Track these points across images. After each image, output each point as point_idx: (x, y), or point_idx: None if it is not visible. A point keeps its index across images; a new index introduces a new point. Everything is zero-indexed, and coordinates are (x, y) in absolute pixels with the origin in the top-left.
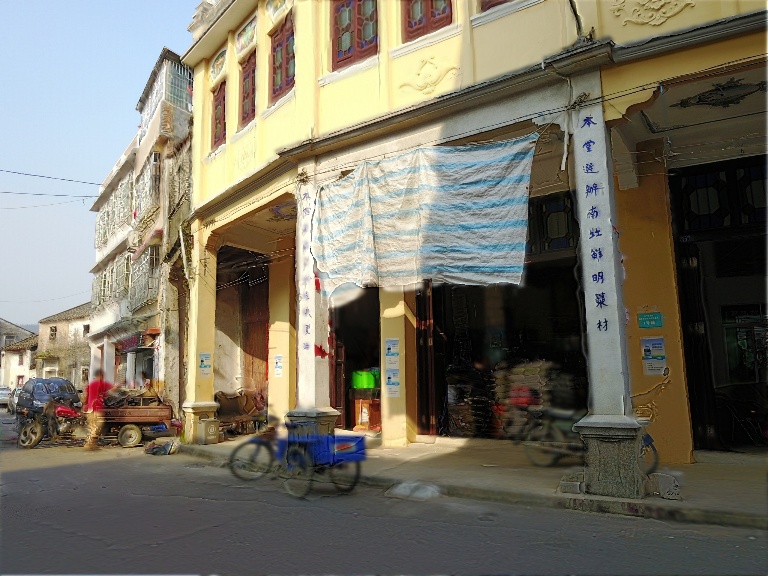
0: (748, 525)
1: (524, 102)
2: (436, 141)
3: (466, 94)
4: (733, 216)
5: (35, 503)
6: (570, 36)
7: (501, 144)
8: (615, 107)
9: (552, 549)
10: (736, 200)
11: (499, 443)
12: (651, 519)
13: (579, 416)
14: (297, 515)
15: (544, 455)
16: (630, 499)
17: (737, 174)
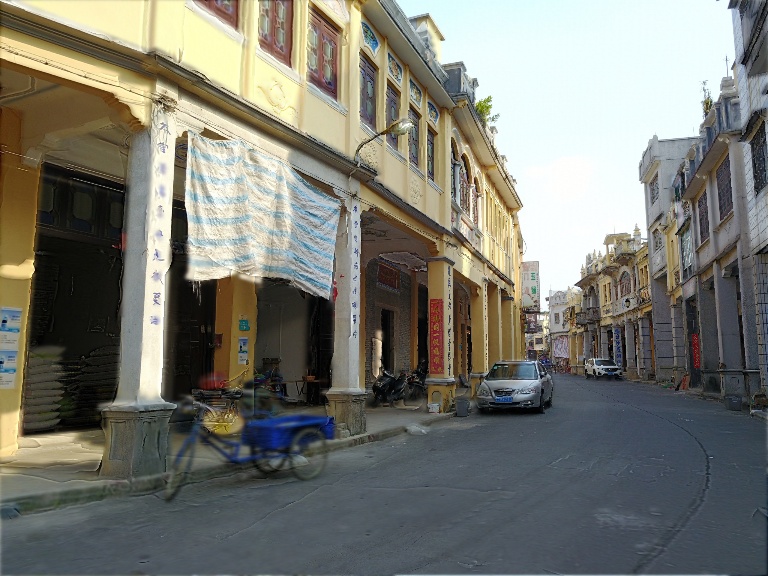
0: None
1: (331, 173)
2: None
3: (318, 146)
4: None
5: (316, 561)
6: (353, 150)
7: (324, 195)
8: None
9: None
10: None
11: (78, 436)
12: (378, 441)
13: (184, 398)
14: None
15: None
16: None
17: None
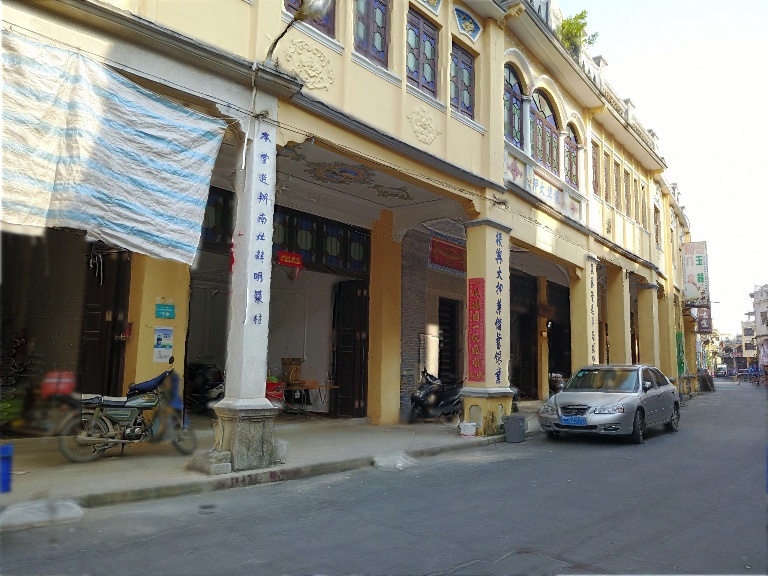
0: (335, 470)
1: (211, 82)
2: (104, 59)
3: (164, 34)
4: (224, 236)
5: None
6: (261, 51)
7: (188, 111)
8: (283, 136)
9: (337, 509)
10: (227, 224)
11: None
12: (291, 480)
13: (67, 405)
14: (57, 573)
15: (48, 452)
16: (270, 468)
17: (230, 204)
